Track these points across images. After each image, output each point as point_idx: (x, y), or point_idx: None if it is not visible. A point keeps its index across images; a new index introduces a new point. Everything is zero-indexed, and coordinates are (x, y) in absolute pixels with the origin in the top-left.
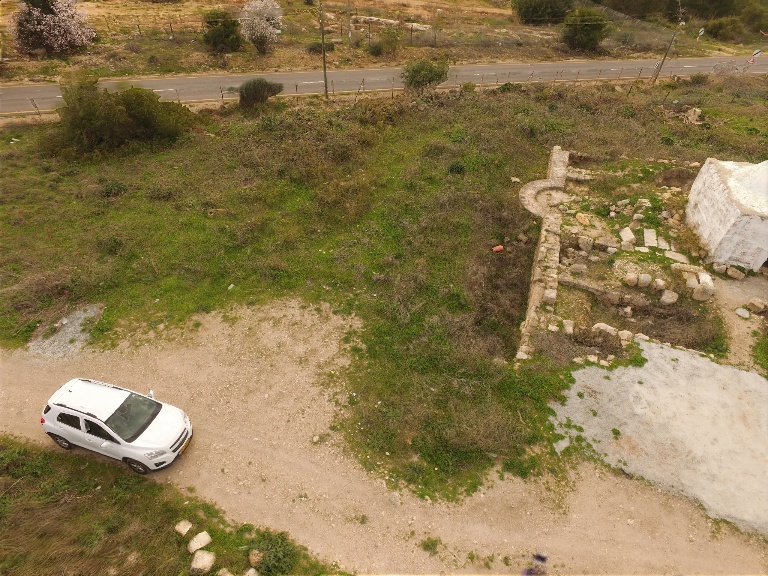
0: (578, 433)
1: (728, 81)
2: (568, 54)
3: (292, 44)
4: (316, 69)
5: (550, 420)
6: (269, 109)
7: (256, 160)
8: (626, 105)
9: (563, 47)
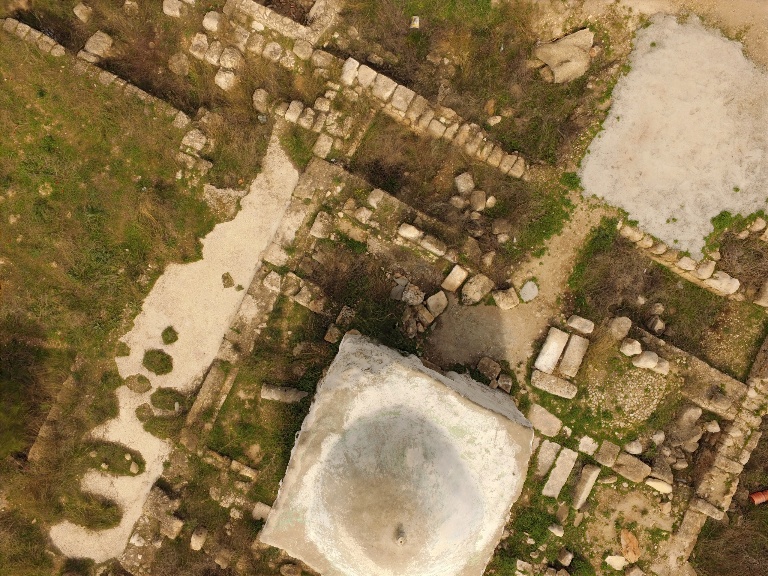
0: None
1: None
2: None
3: None
4: None
5: None
6: None
7: None
8: None
9: None
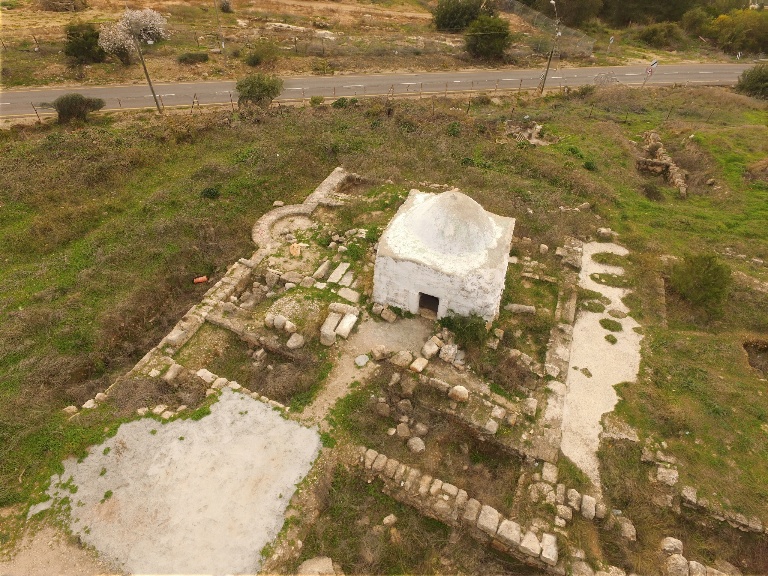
0: (68, 494)
1: (606, 94)
2: (469, 63)
3: (165, 55)
4: (180, 81)
5: (51, 479)
6: (86, 125)
7: (3, 182)
8: (454, 122)
9: (464, 56)
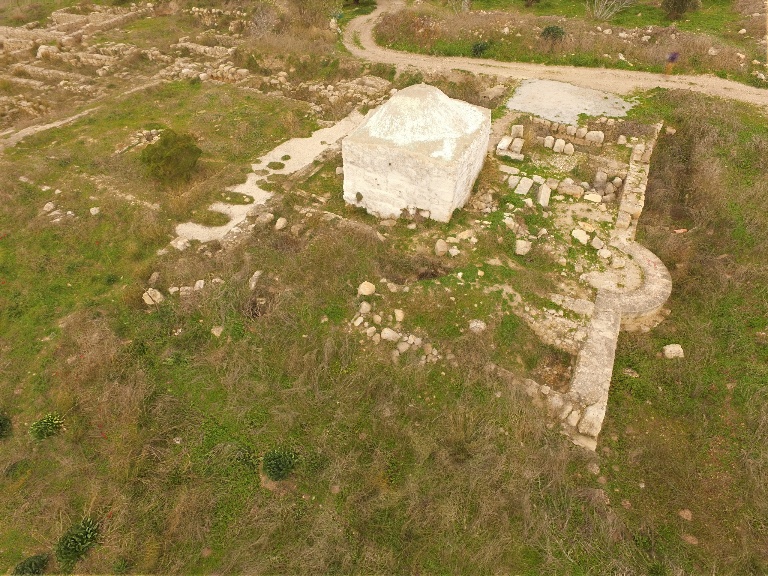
0: None
1: None
2: None
3: None
4: None
5: None
6: None
7: None
8: None
9: None
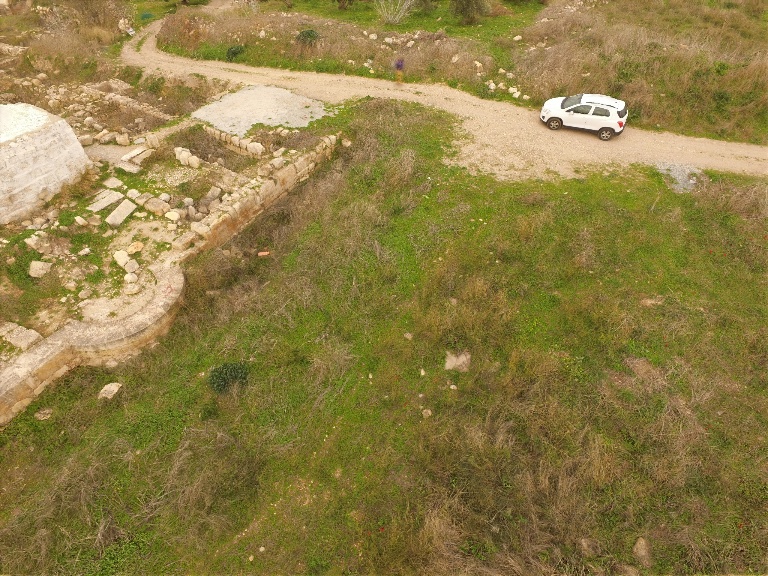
0: (327, 109)
1: None
2: None
3: None
4: None
5: None
6: None
7: None
8: None
9: None
